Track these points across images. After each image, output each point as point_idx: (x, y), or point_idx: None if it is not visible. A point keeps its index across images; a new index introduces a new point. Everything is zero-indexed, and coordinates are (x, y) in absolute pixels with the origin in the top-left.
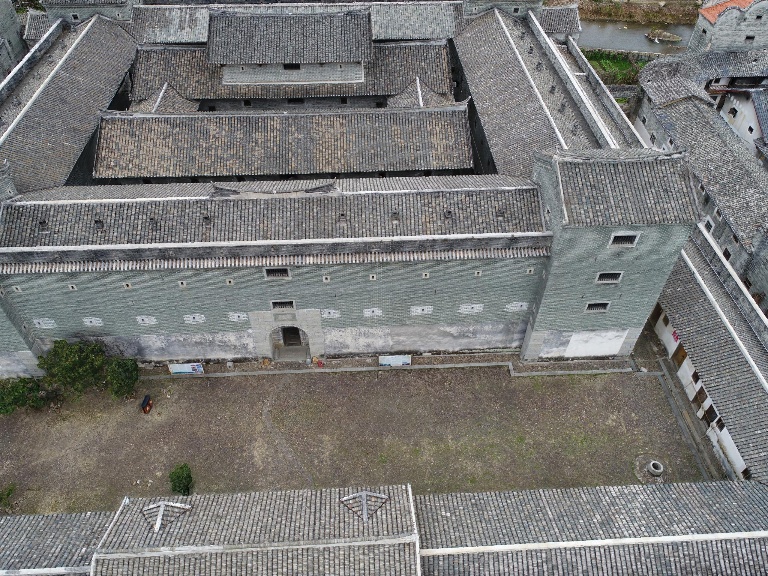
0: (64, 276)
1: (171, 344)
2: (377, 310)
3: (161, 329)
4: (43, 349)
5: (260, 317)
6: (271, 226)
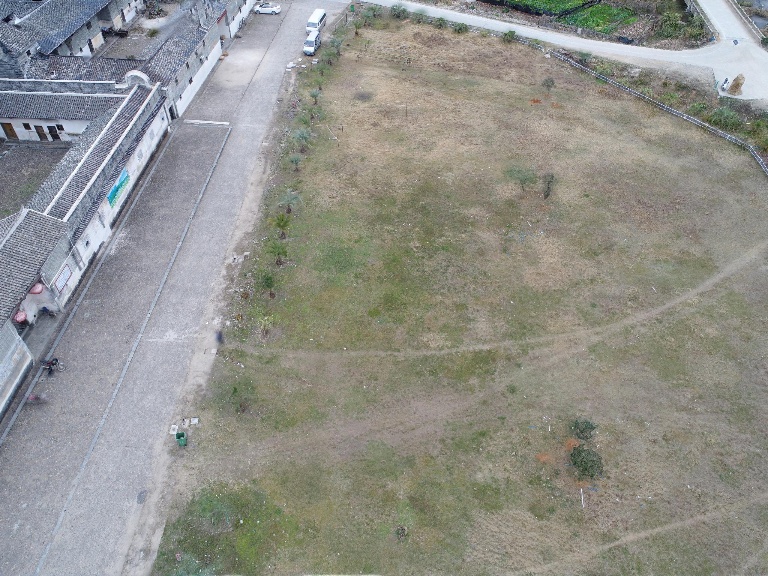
0: None
1: None
2: None
3: None
4: None
5: None
6: None
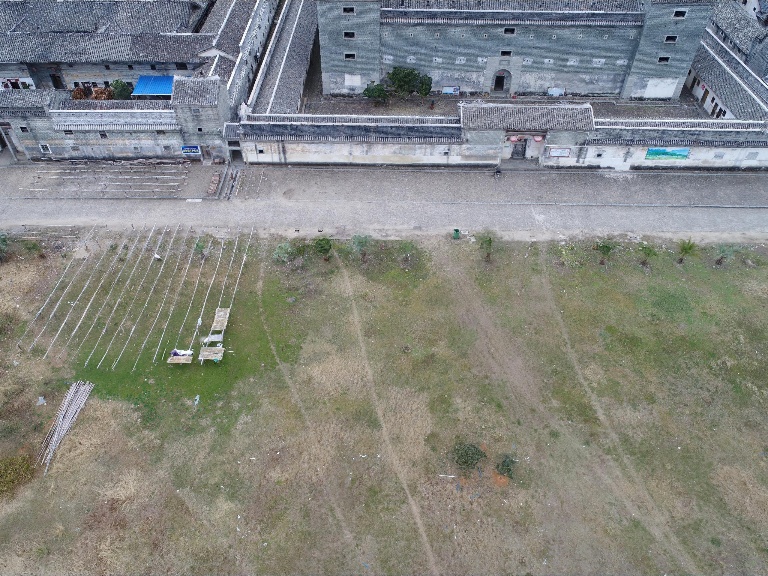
0: (411, 27)
1: (443, 78)
2: (551, 60)
3: (442, 67)
4: (380, 78)
5: (492, 62)
6: (508, 8)
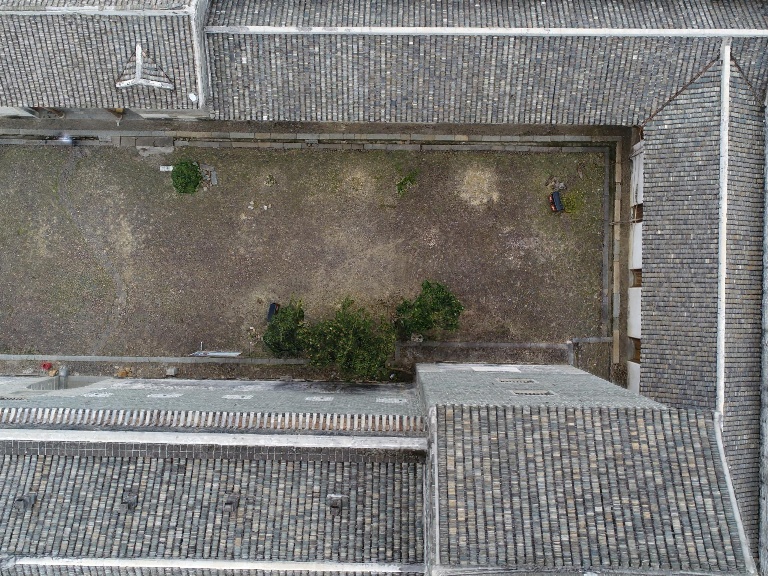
0: None
1: None
2: None
3: None
4: None
5: None
6: None
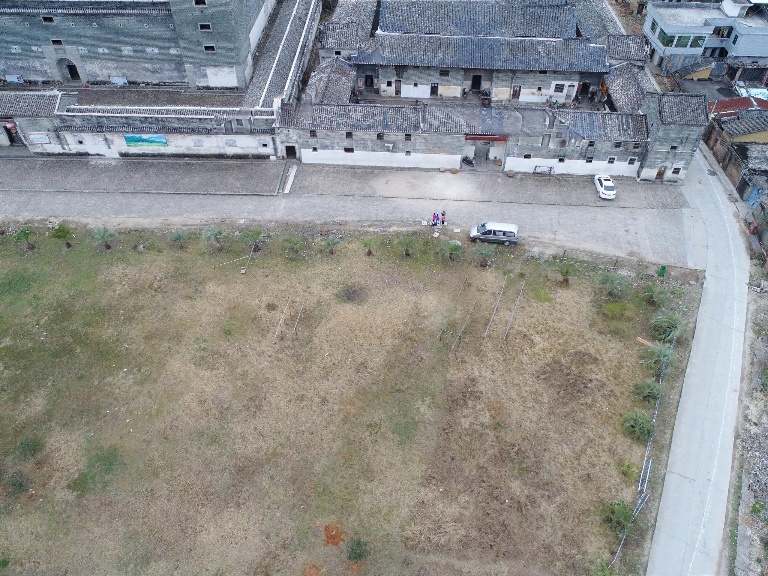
0: None
1: (8, 67)
2: (105, 49)
3: (1, 56)
4: None
5: (48, 50)
6: None
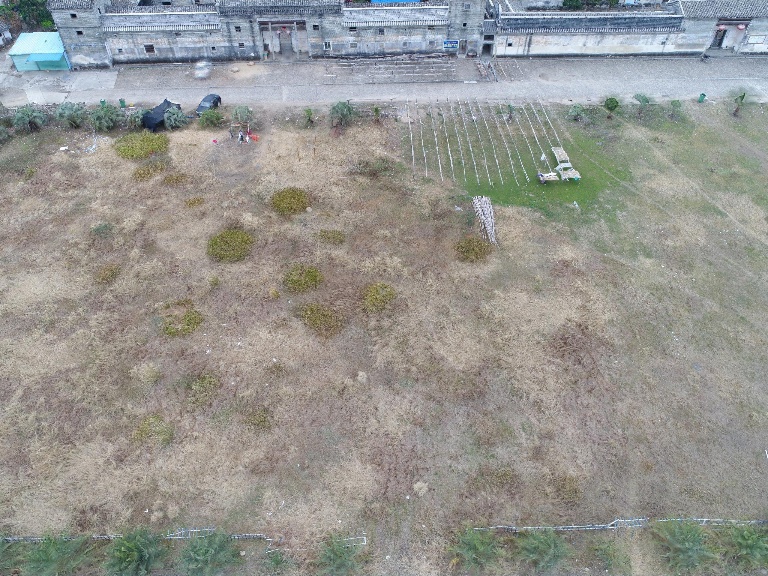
0: None
1: None
2: None
3: None
4: None
5: None
6: None
